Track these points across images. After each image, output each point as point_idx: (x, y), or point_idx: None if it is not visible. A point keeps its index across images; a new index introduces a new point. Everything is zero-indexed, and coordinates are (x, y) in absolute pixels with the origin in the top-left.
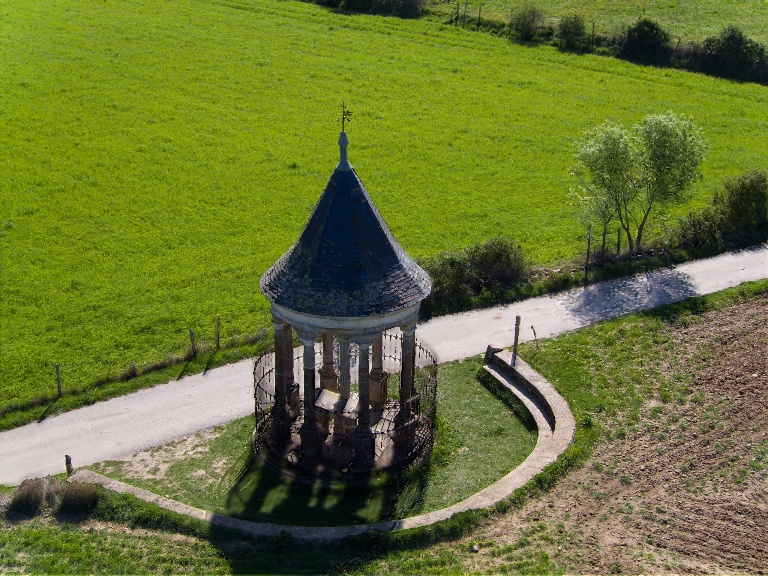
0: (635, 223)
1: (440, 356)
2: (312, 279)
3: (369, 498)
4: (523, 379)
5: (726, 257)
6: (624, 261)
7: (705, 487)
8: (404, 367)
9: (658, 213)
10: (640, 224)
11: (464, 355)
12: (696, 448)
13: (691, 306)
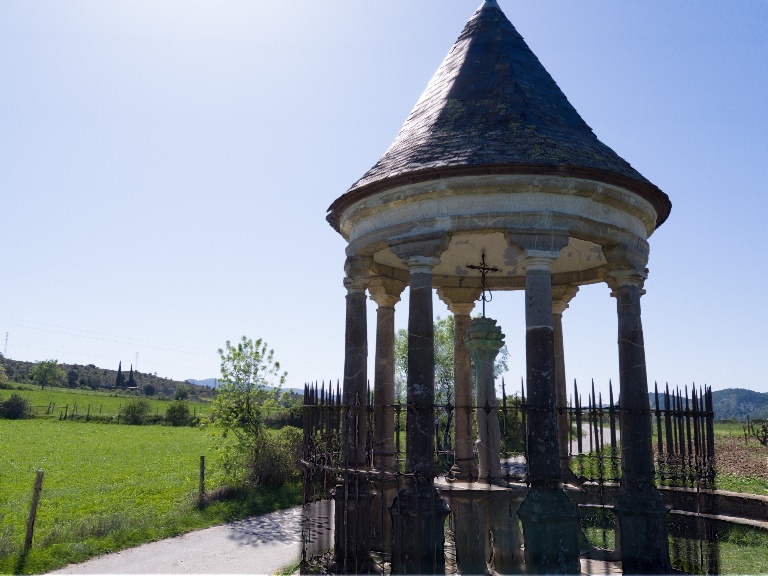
0: (440, 429)
1: None
2: (534, 124)
3: None
4: (604, 489)
5: (520, 457)
6: None
7: None
8: None
9: None
10: (445, 430)
11: None
12: None
13: None
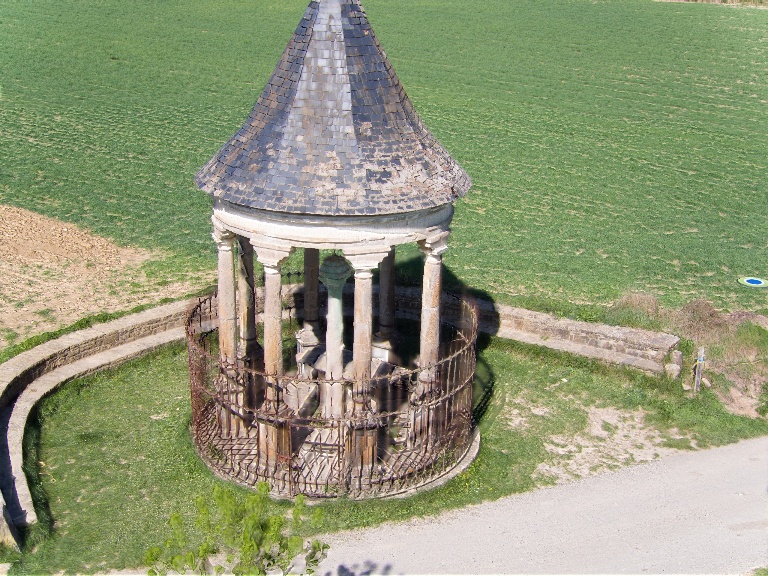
0: None
1: None
2: None
3: None
4: None
5: None
6: None
7: None
8: None
9: None
10: None
11: None
12: None
13: None
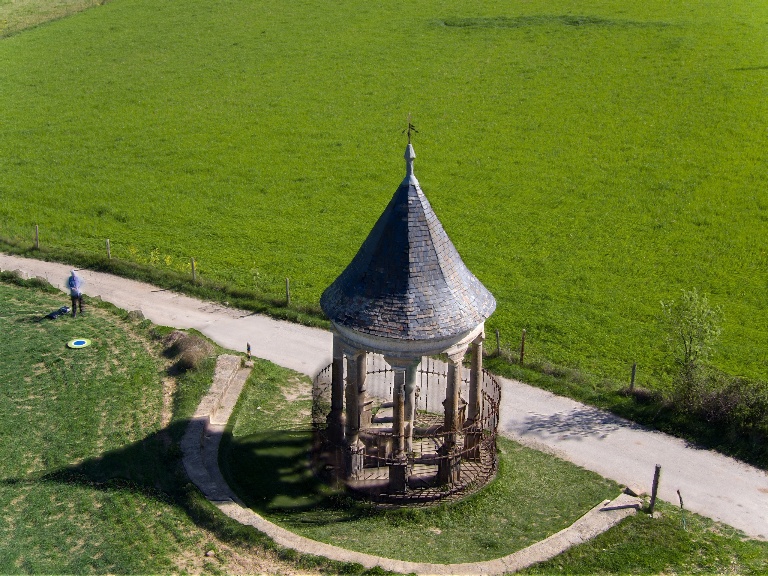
0: None
1: (622, 474)
2: None
3: (308, 496)
4: None
5: None
6: None
7: None
8: None
9: None
10: None
11: None
12: None
13: None
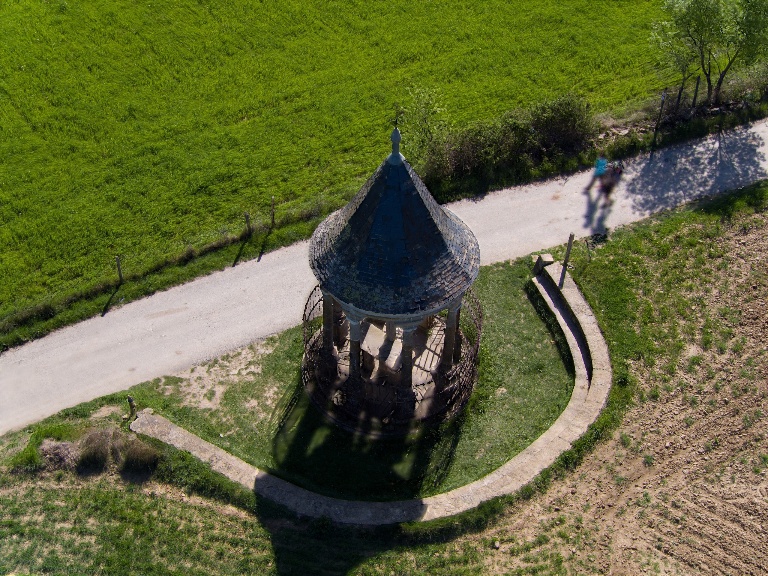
0: (718, 69)
1: (491, 254)
2: (359, 271)
3: (407, 453)
4: (569, 307)
5: None
6: (698, 117)
7: (723, 475)
8: (448, 335)
9: (744, 61)
10: (723, 70)
11: (515, 254)
12: (724, 419)
13: (756, 202)
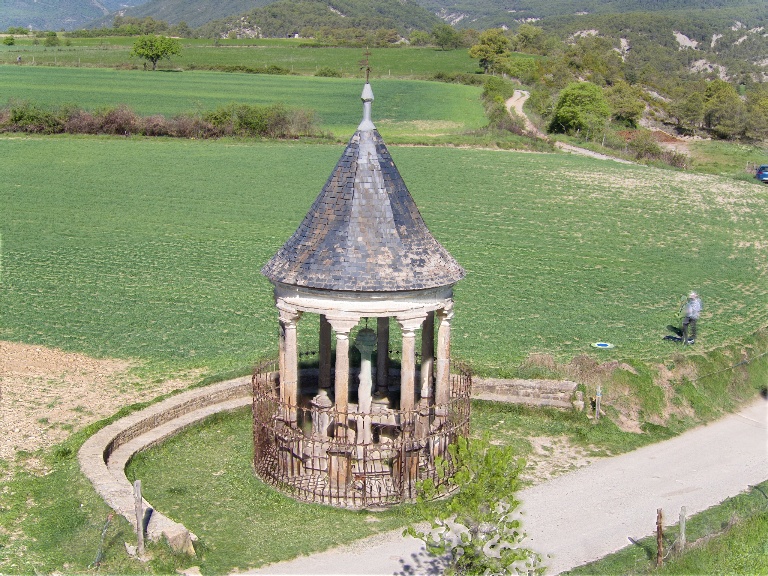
0: None
1: (275, 575)
2: None
3: None
4: None
5: None
6: None
7: None
8: None
9: None
10: None
11: None
12: None
13: None
